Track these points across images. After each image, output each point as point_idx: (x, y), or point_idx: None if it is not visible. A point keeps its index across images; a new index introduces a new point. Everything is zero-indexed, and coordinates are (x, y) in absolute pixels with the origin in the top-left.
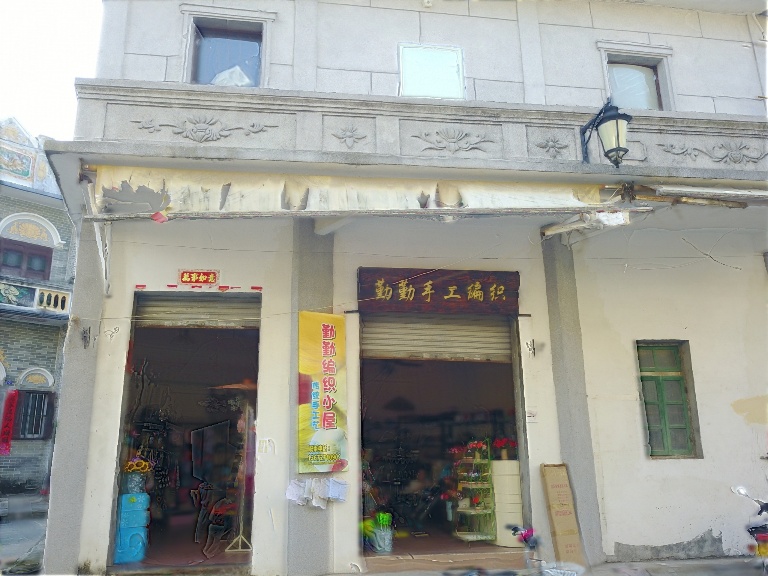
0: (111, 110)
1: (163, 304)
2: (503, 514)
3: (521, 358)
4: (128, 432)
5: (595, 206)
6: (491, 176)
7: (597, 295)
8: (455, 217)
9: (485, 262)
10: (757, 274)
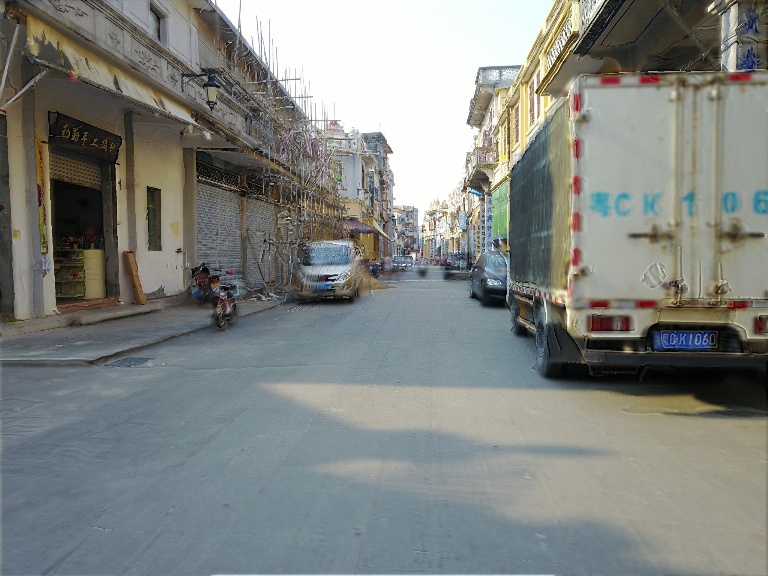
0: None
1: None
2: (90, 281)
3: (116, 190)
4: None
5: None
6: (168, 94)
7: (136, 157)
8: (161, 115)
9: (111, 127)
10: (180, 159)
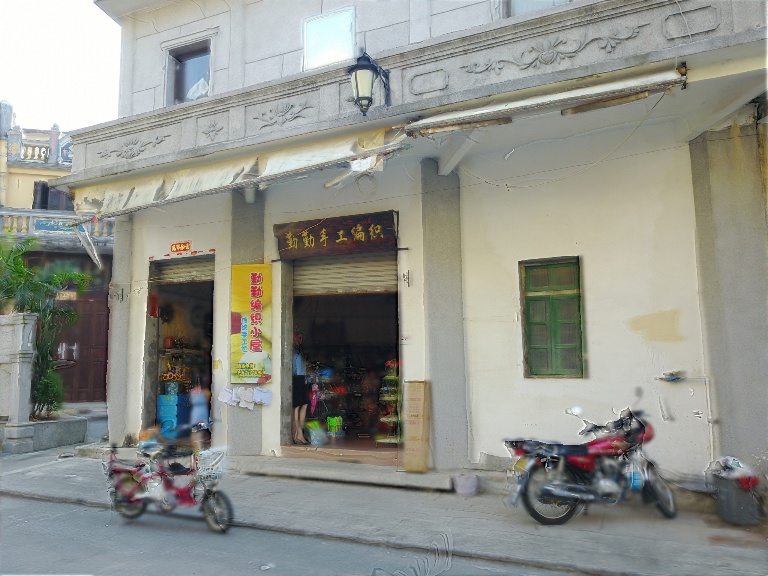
0: (88, 148)
1: (171, 268)
2: None
3: None
4: (156, 355)
5: (351, 155)
6: (293, 142)
7: (480, 220)
8: None
9: (362, 206)
10: (677, 169)
